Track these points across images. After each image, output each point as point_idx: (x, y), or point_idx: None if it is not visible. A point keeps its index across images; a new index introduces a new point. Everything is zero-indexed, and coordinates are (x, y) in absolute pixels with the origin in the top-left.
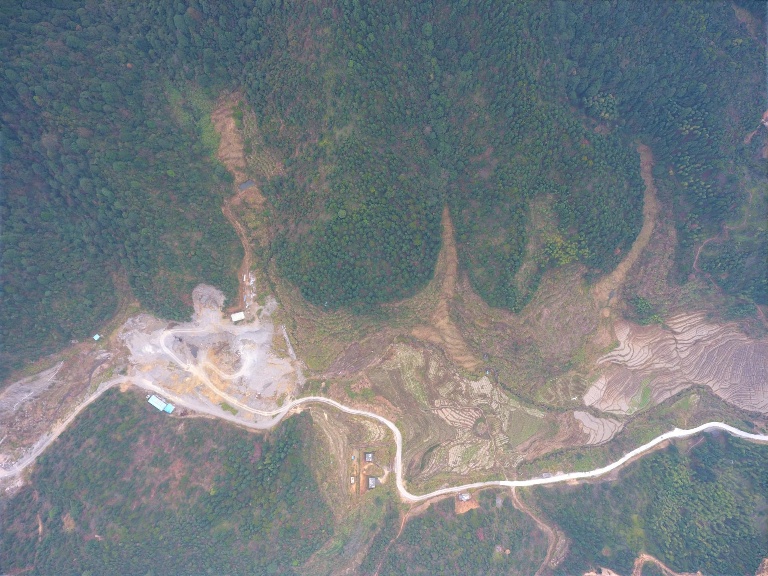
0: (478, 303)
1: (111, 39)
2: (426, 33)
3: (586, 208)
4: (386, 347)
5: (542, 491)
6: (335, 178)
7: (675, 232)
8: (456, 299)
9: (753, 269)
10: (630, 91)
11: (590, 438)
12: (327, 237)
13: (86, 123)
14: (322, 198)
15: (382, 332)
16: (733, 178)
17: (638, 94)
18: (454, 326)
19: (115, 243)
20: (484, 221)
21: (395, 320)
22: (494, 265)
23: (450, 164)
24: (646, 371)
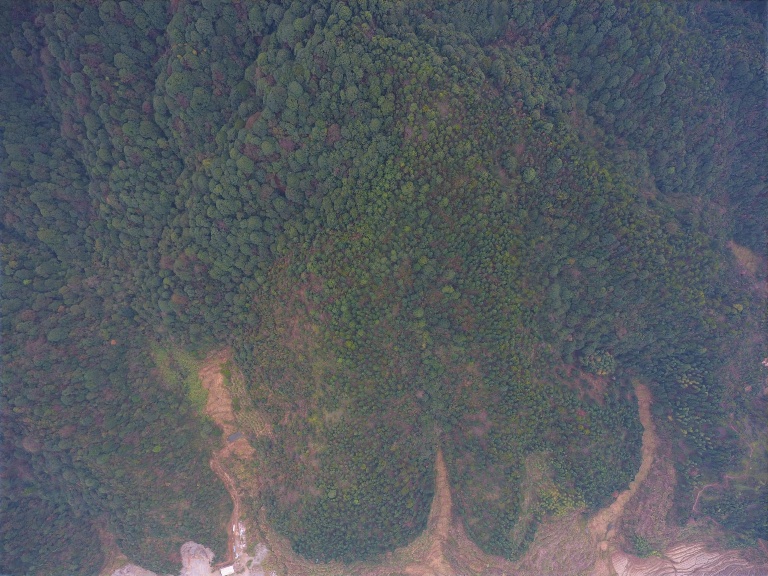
0: (473, 549)
1: (95, 314)
2: (417, 316)
3: (583, 470)
4: None
5: None
6: (325, 459)
7: (674, 471)
8: (450, 544)
9: (754, 514)
10: (628, 348)
11: None
12: (317, 512)
13: (68, 420)
14: (312, 473)
15: (375, 572)
16: (733, 435)
17: (636, 352)
18: (448, 565)
19: (101, 511)
20: (478, 476)
21: (388, 562)
22: (489, 520)
23: (443, 416)
24: None
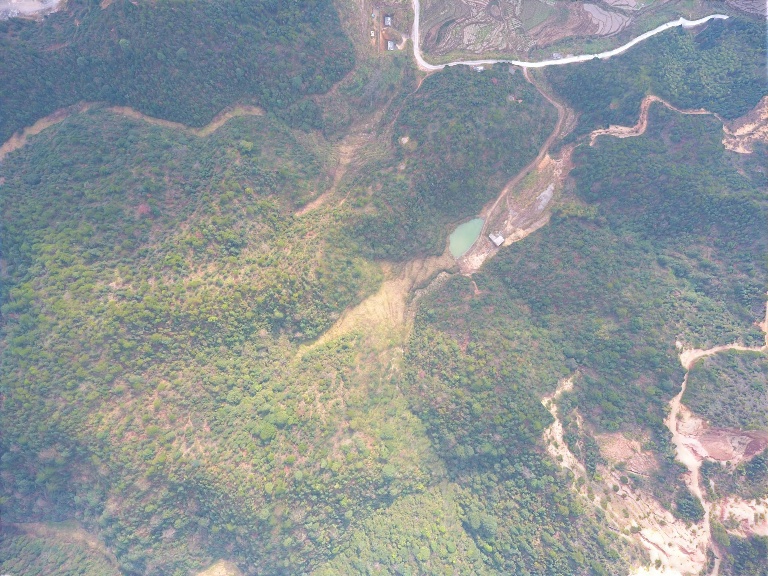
0: None
1: None
2: None
3: None
4: None
5: (553, 65)
6: None
7: None
8: None
9: None
10: None
11: (599, 28)
12: None
13: None
14: None
15: None
16: None
17: None
18: None
19: None
20: None
21: None
22: None
23: None
24: None
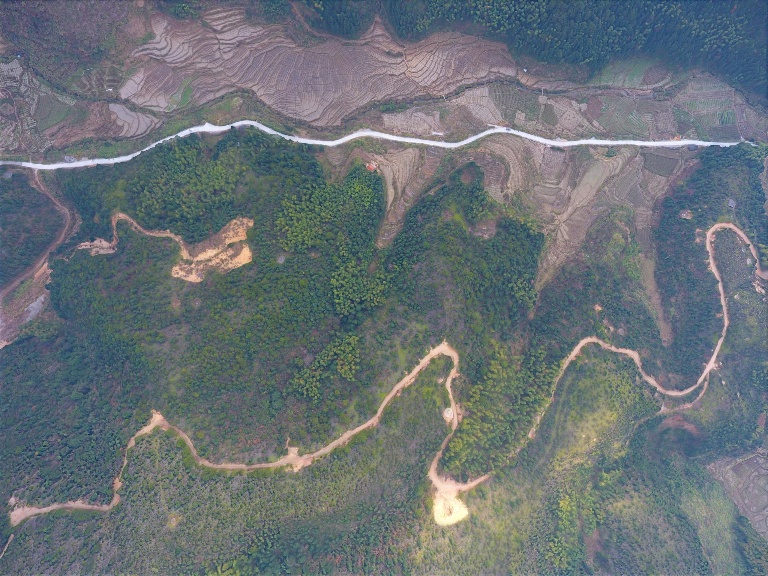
0: None
1: None
2: None
3: None
4: None
5: (58, 170)
6: None
7: None
8: None
9: None
10: None
11: (123, 130)
12: None
13: None
14: None
15: None
16: None
17: None
18: None
19: None
20: None
21: None
22: None
23: None
24: (188, 70)
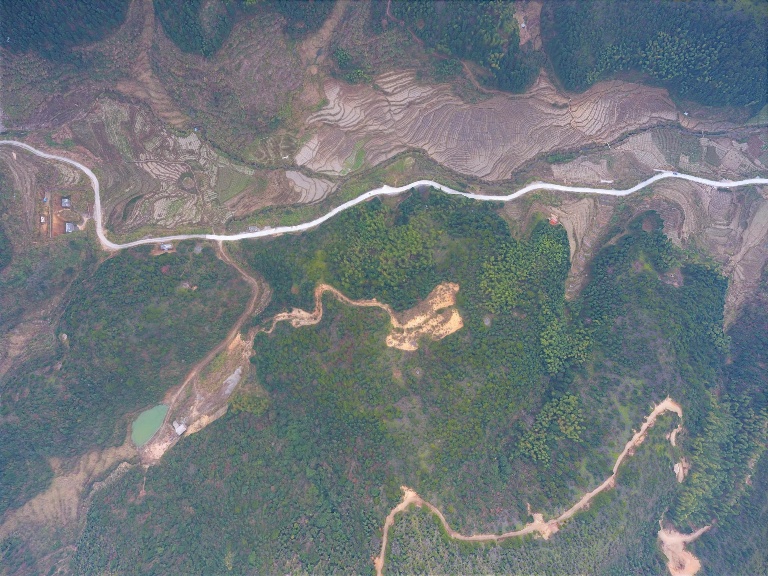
0: (172, 49)
1: None
2: None
3: None
4: (92, 102)
5: (244, 241)
6: None
7: None
8: None
9: (443, 14)
10: None
11: (301, 196)
12: None
13: None
14: None
15: (85, 85)
16: None
17: None
18: (158, 80)
19: None
20: None
21: (95, 70)
22: (176, 2)
23: None
24: (360, 133)
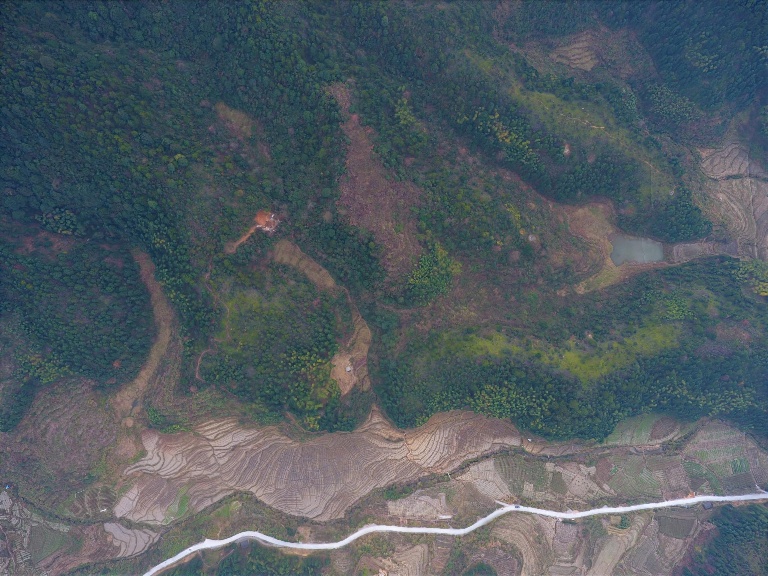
0: None
1: None
2: None
3: (42, 330)
4: None
5: None
6: None
7: None
8: None
9: (254, 380)
10: (89, 206)
11: (120, 551)
12: None
13: None
14: None
15: None
16: (202, 293)
17: None
18: None
19: None
20: None
21: None
22: None
23: None
24: (183, 479)
